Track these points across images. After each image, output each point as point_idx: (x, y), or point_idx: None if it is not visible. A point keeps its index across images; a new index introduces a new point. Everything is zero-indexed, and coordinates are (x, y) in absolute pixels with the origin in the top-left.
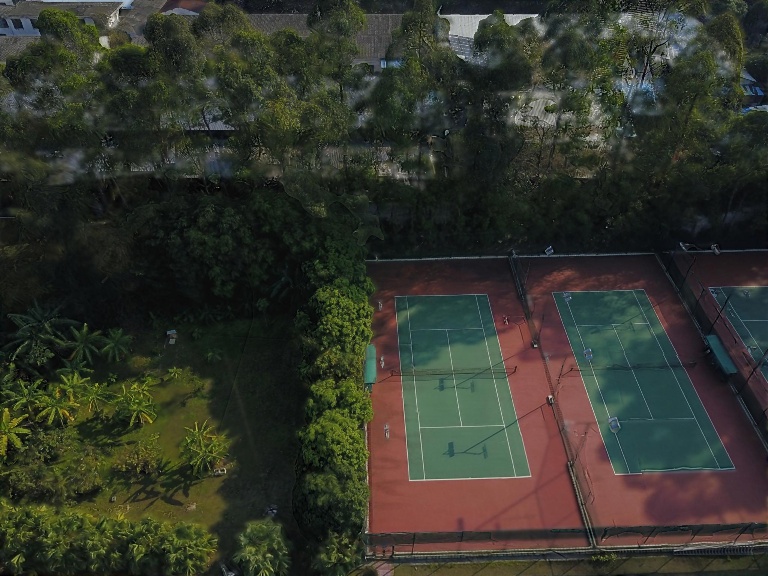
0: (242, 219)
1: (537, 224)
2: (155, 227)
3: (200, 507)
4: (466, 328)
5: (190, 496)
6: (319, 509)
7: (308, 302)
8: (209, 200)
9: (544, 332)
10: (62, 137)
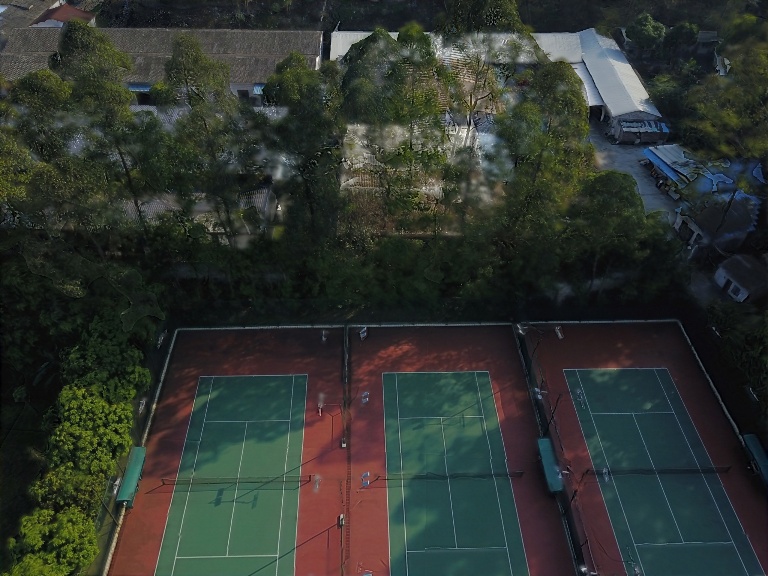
0: None
1: (373, 291)
2: None
3: None
4: (270, 420)
5: None
6: None
7: None
8: None
9: (359, 427)
10: None
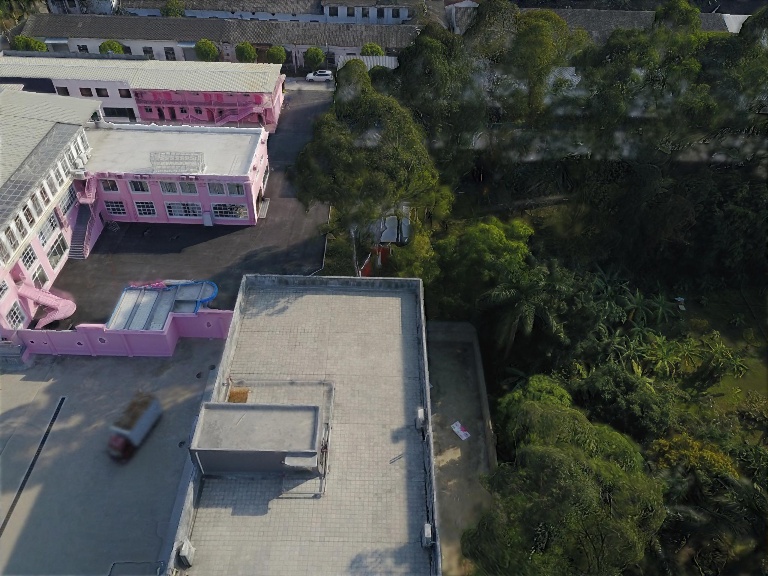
0: None
1: None
2: None
3: None
4: None
5: None
6: None
7: None
8: (735, 178)
9: None
10: (698, 115)
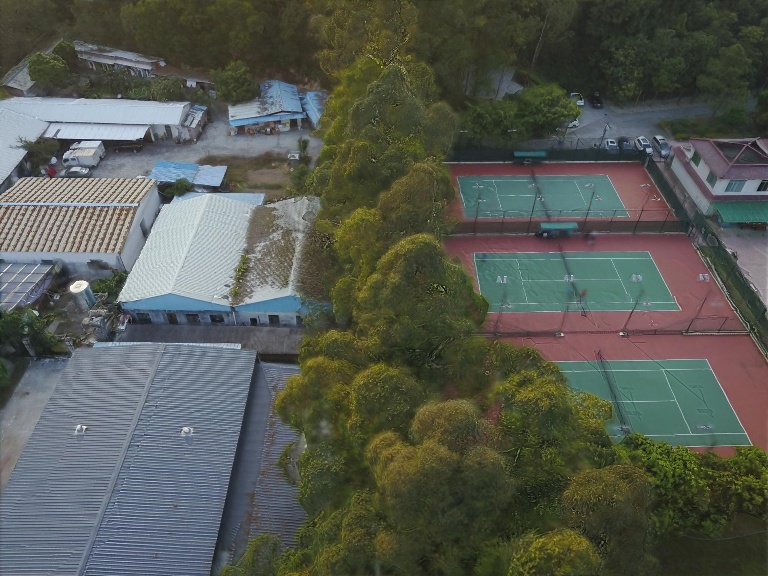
0: None
1: None
2: None
3: None
4: None
5: None
6: None
7: None
8: None
9: (543, 326)
10: None
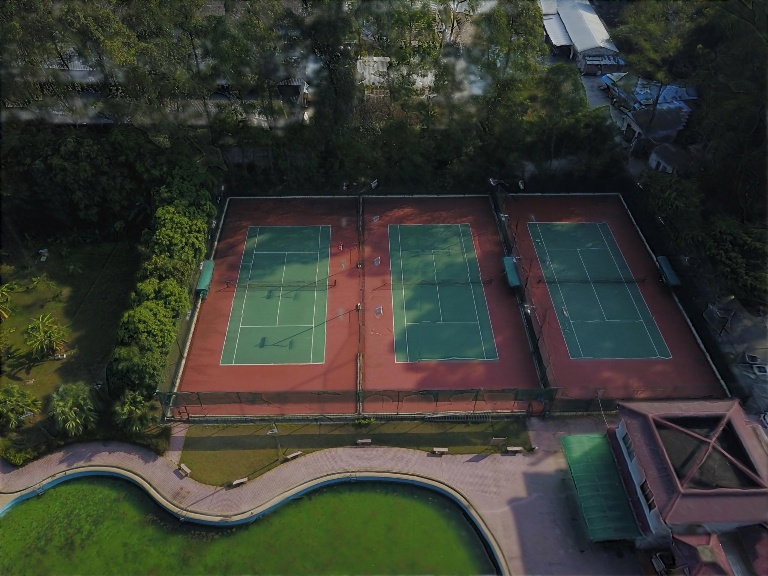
0: (100, 149)
1: (381, 166)
2: (25, 156)
3: (37, 382)
4: (304, 252)
5: (31, 374)
6: (120, 372)
7: (152, 220)
8: (73, 133)
9: (371, 255)
10: None
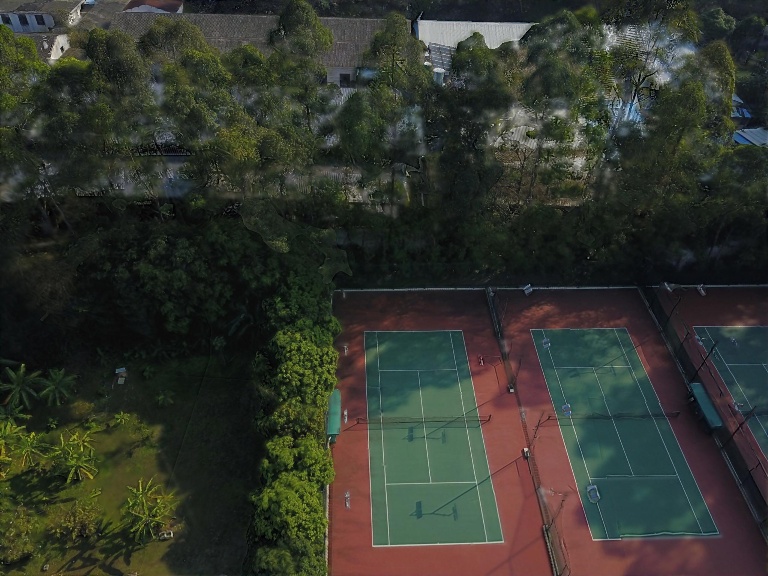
0: (198, 251)
1: (516, 256)
2: (102, 258)
3: None
4: (439, 369)
5: (131, 564)
6: None
7: (268, 345)
8: (162, 230)
9: (521, 375)
10: None
